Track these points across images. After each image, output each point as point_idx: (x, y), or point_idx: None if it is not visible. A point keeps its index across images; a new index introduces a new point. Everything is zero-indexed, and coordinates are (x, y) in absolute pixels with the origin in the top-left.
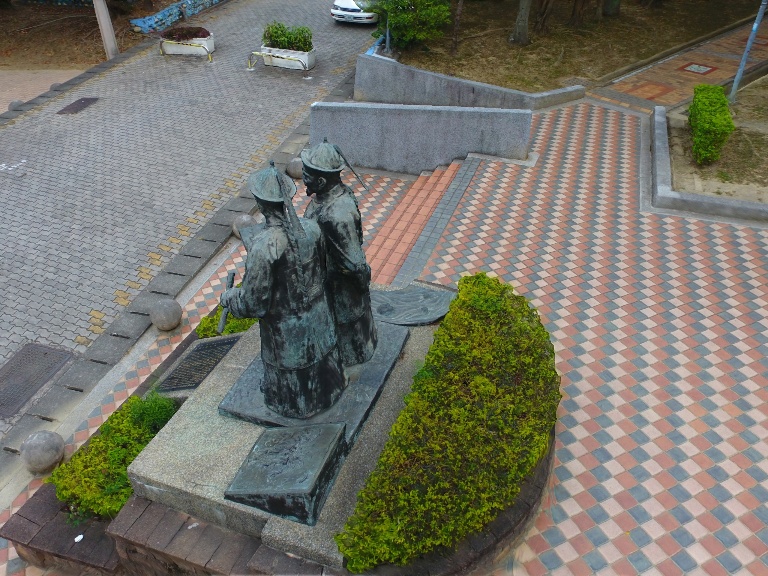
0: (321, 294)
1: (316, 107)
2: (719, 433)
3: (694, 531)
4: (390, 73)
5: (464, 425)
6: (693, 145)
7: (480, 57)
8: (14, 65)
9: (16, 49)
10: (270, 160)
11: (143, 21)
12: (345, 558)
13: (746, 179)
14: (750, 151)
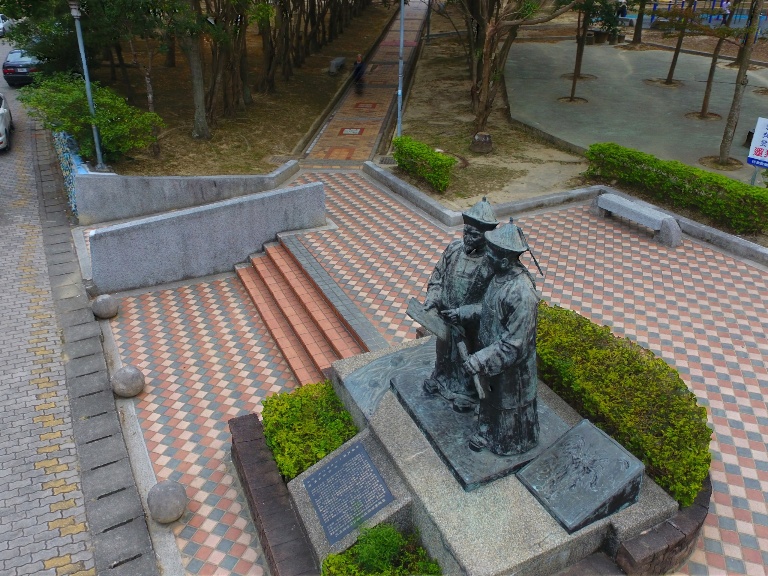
0: None
1: (97, 235)
2: (653, 332)
3: (712, 383)
4: (120, 187)
5: (627, 379)
6: (430, 179)
7: (182, 156)
8: None
9: None
10: (59, 311)
11: None
12: (679, 501)
13: (473, 193)
14: (453, 176)
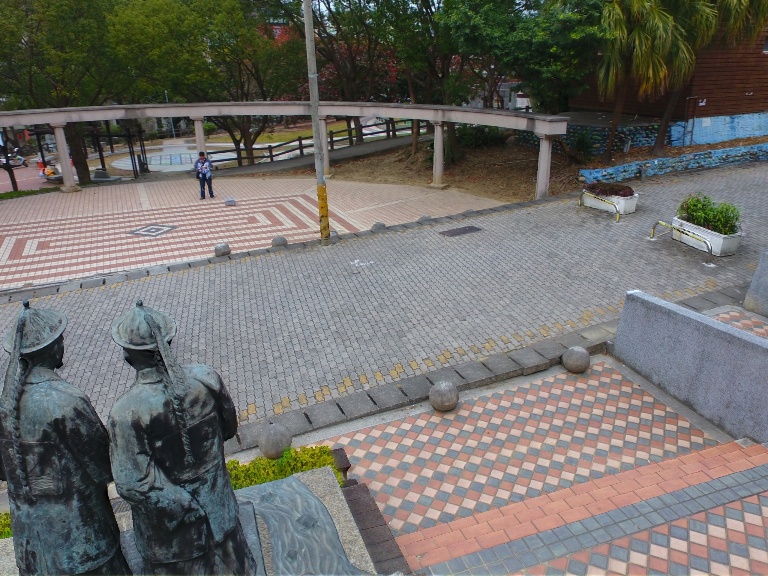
0: (60, 495)
1: (631, 296)
2: None
3: None
4: None
5: None
6: None
7: None
8: (471, 190)
9: (483, 178)
10: (557, 338)
11: (590, 172)
12: None
13: None
14: None
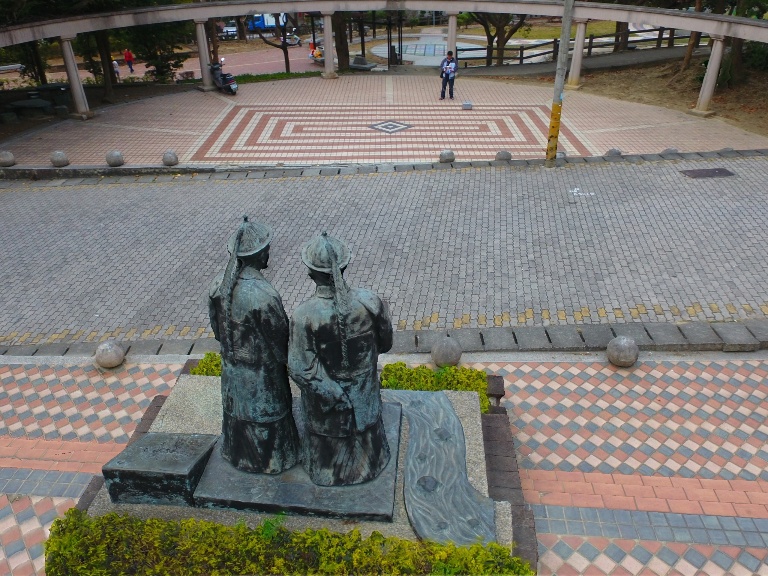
0: (252, 363)
1: None
2: None
3: None
4: None
5: None
6: None
7: None
8: (742, 122)
9: (762, 109)
10: None
11: None
12: None
13: None
14: None
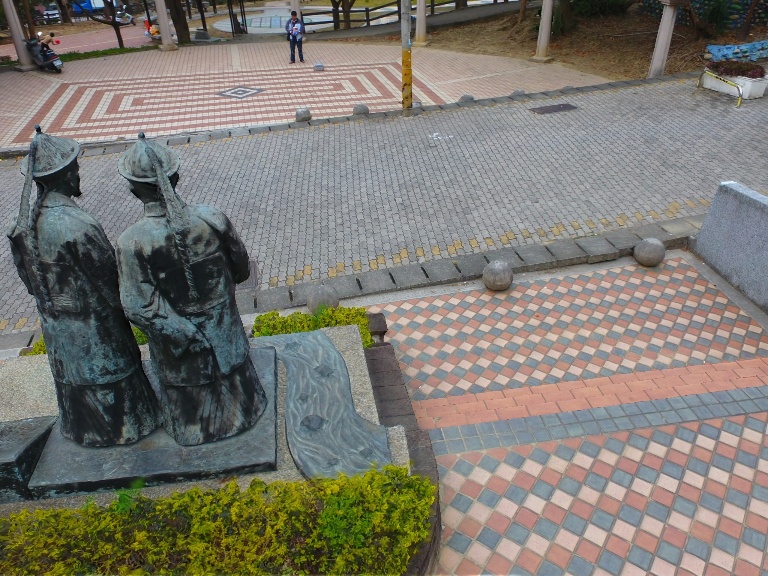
0: (78, 312)
1: (725, 187)
2: None
3: None
4: None
5: None
6: None
7: None
8: (577, 65)
9: (593, 52)
10: (634, 228)
11: (719, 48)
12: None
13: None
14: None
